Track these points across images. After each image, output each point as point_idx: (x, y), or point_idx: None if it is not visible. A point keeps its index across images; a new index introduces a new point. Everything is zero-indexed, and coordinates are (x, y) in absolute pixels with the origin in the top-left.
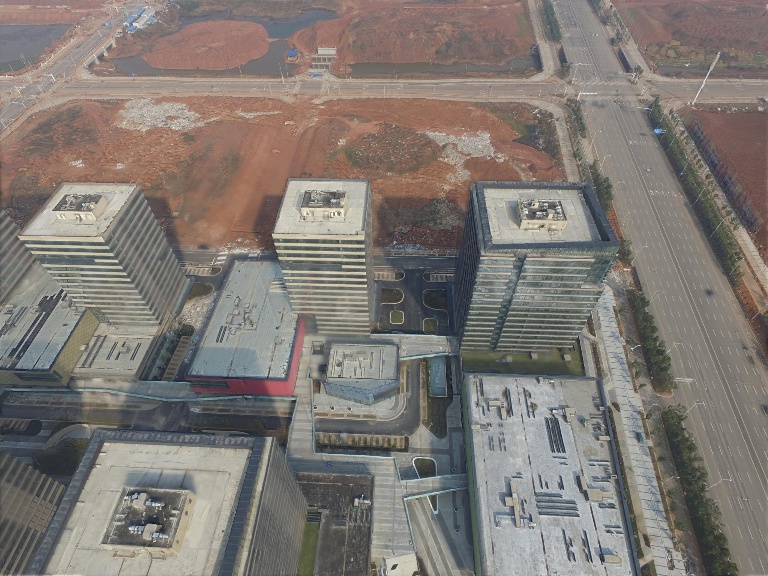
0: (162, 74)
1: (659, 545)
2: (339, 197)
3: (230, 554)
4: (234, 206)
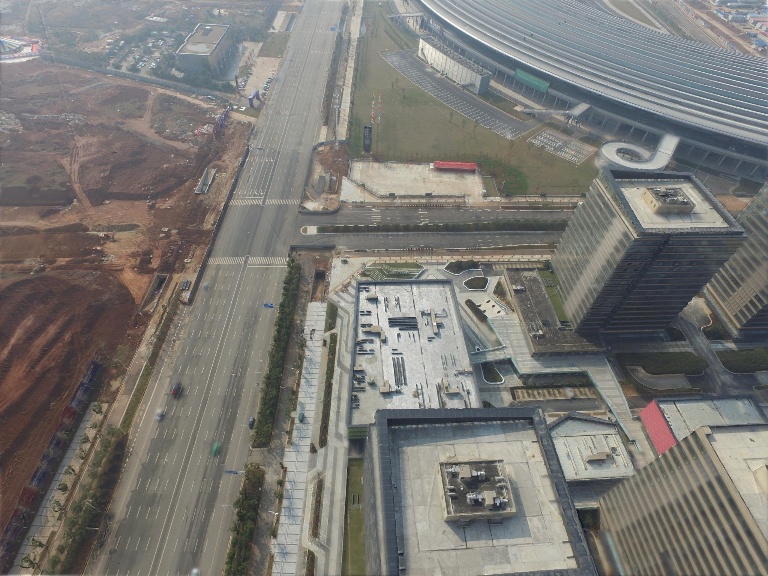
0: None
1: (317, 341)
2: None
3: (617, 186)
4: None
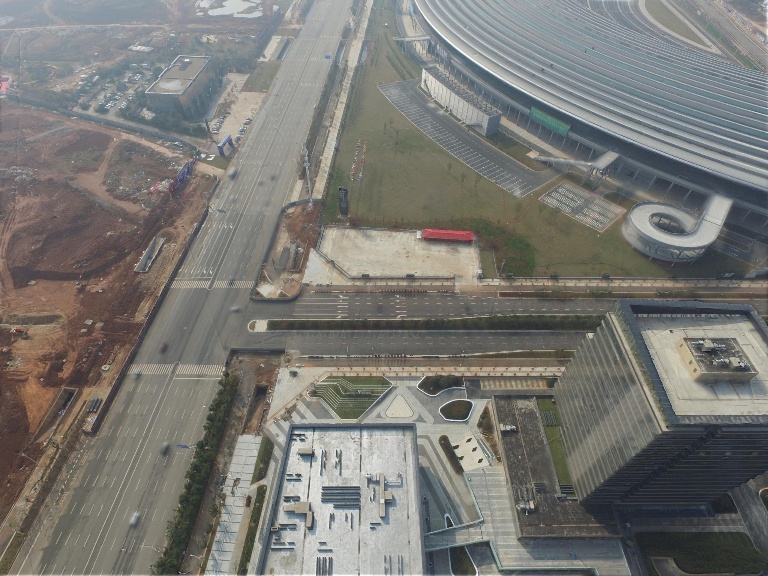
0: None
1: (239, 498)
2: None
3: (639, 336)
4: None
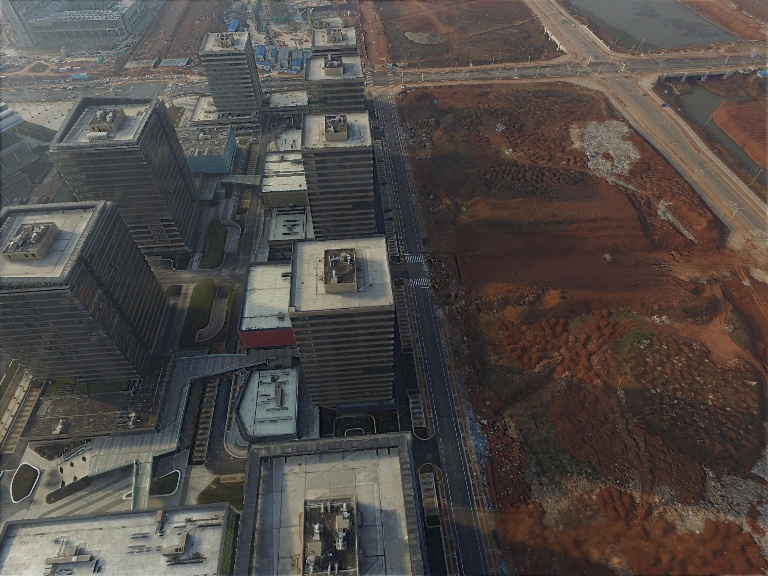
0: (698, 125)
1: None
2: (346, 278)
3: None
4: (486, 246)
